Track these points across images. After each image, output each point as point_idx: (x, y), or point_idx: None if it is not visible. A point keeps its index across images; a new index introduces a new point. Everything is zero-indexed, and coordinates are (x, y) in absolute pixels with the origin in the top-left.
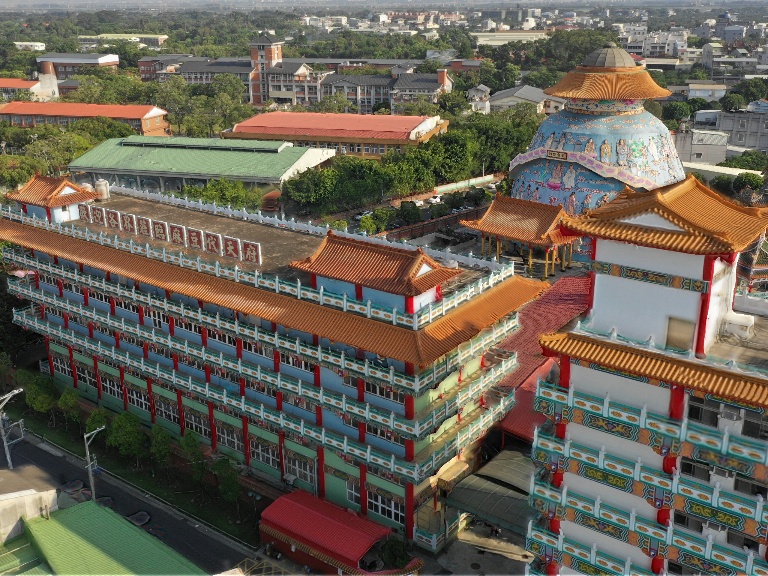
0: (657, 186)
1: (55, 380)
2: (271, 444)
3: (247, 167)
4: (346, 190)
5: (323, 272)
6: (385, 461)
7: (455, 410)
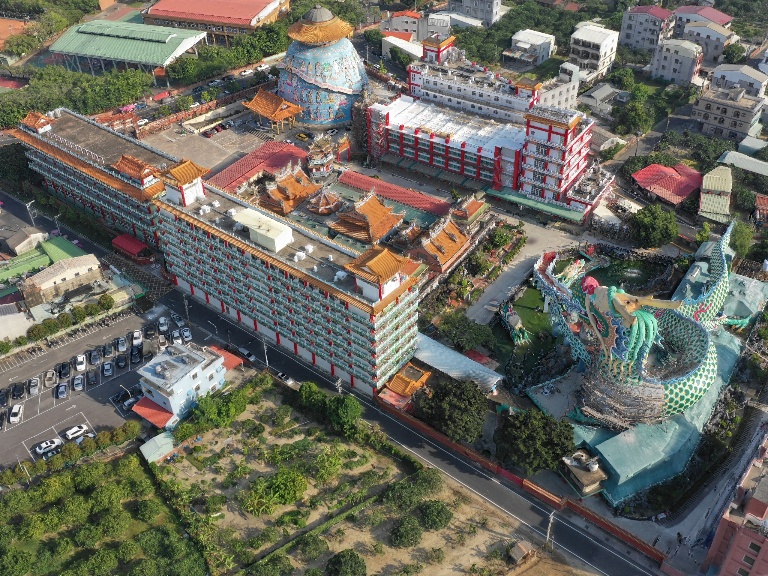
0: (335, 87)
1: (49, 189)
2: (120, 218)
3: (147, 55)
4: (201, 70)
5: (120, 169)
6: (144, 226)
7: None
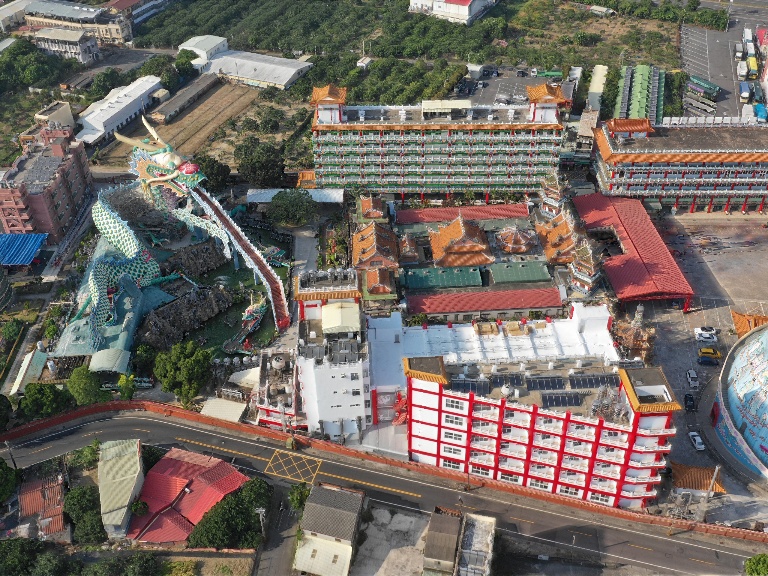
0: None
1: None
2: None
3: None
4: None
5: None
6: None
7: None
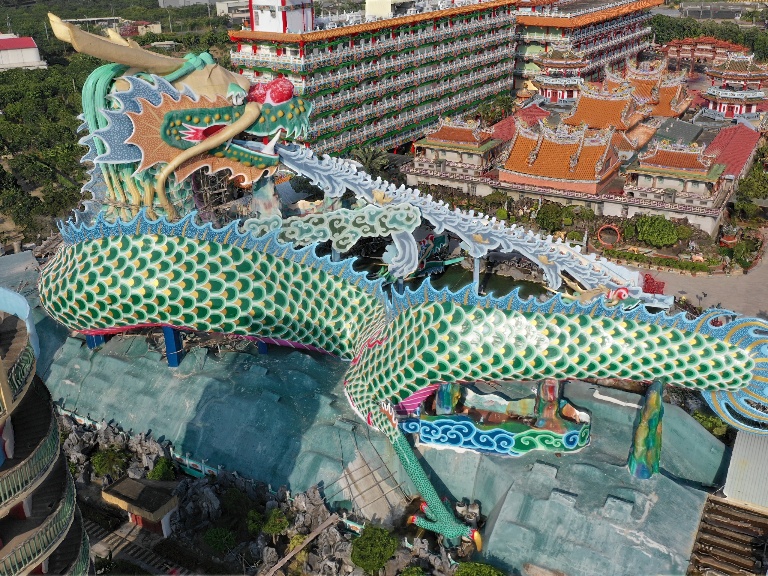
0: None
1: None
2: None
3: None
4: None
5: None
6: None
7: (523, 56)
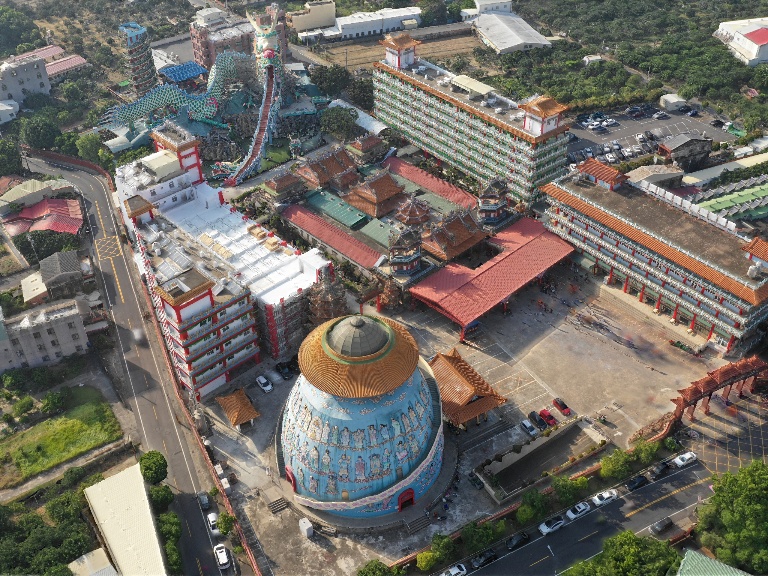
0: None
1: None
2: None
3: None
4: None
5: None
6: None
7: None
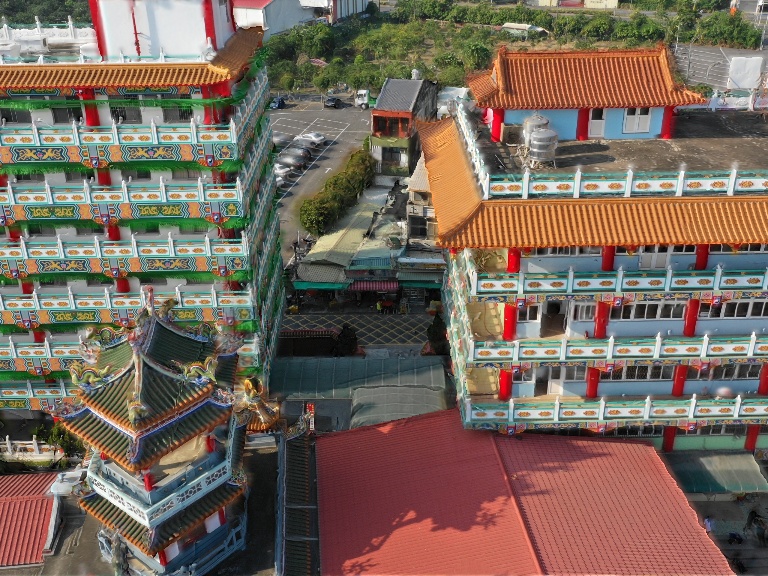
0: None
1: None
2: None
3: None
4: None
5: None
6: None
7: (450, 270)
